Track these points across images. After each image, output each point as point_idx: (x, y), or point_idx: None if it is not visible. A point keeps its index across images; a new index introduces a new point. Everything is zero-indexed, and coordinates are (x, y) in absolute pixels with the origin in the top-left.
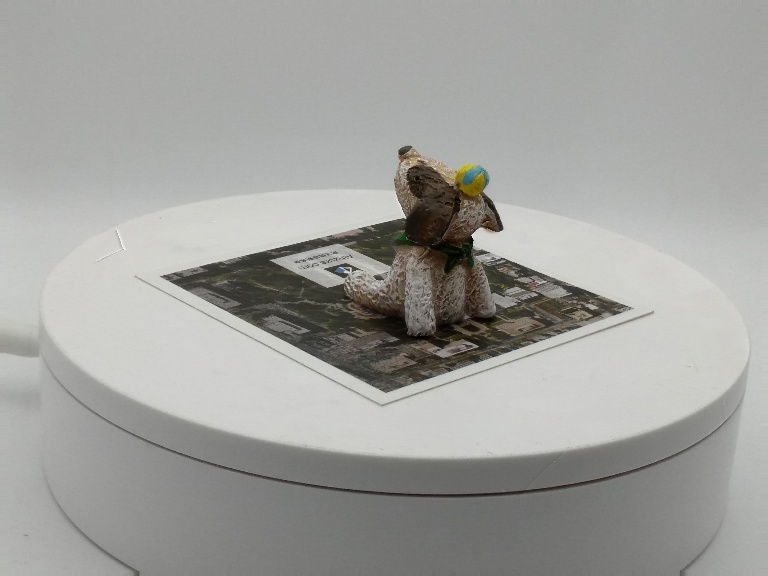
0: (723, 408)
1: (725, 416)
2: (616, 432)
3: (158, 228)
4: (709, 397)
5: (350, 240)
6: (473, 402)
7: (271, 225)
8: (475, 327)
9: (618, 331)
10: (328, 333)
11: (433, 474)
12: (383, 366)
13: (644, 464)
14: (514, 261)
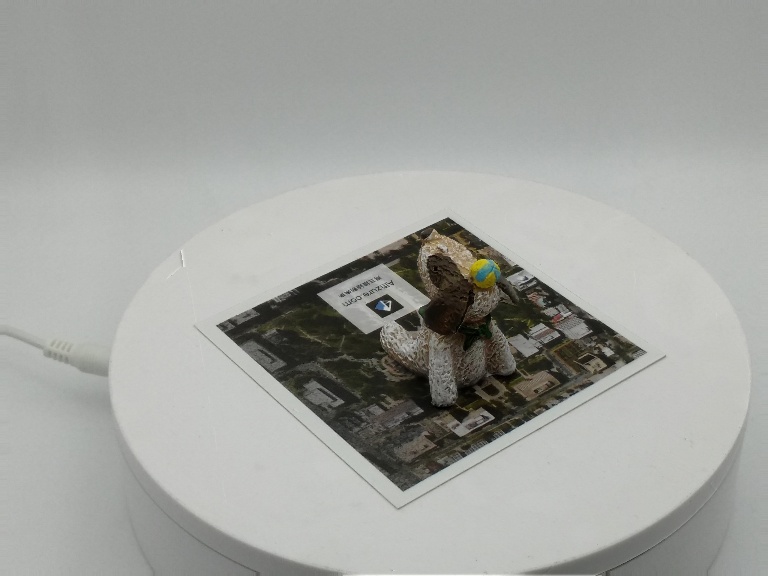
0: (711, 486)
1: (715, 488)
2: (602, 538)
3: (219, 247)
4: (696, 483)
5: (394, 257)
6: (479, 501)
7: (323, 236)
8: (495, 388)
9: (628, 386)
10: (360, 405)
11: None
12: (405, 452)
13: (629, 558)
14: (545, 282)
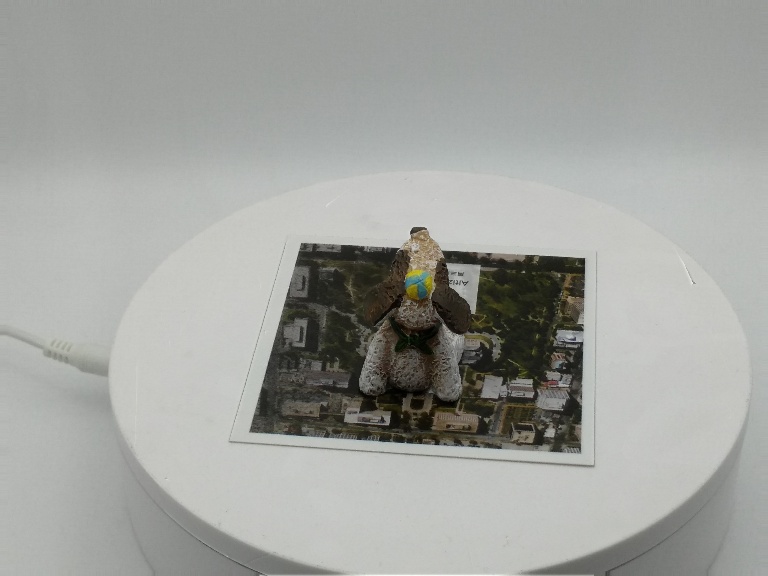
0: None
1: None
2: (332, 561)
3: (385, 190)
4: (463, 574)
5: (495, 265)
6: (289, 474)
7: (469, 221)
8: (421, 404)
9: (526, 469)
10: (311, 355)
11: (184, 516)
12: (291, 407)
13: None
14: (585, 350)
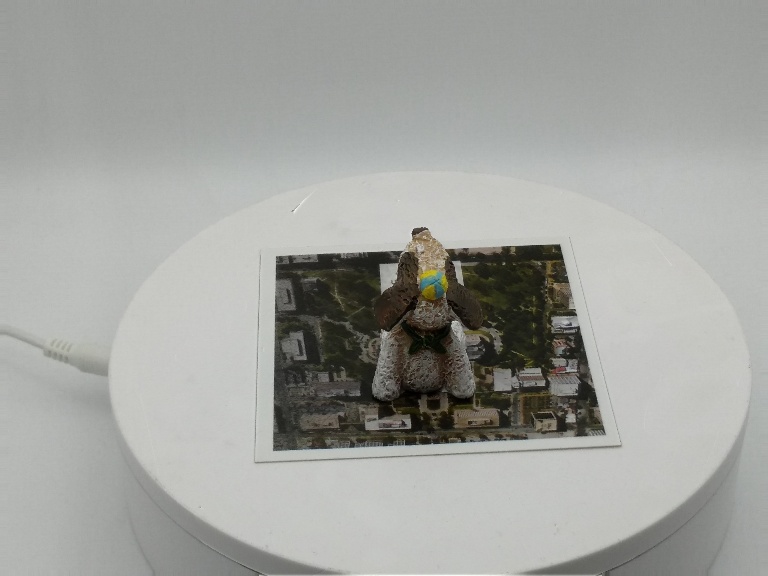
0: None
1: None
2: (390, 569)
3: (346, 195)
4: (522, 567)
5: (475, 260)
6: (324, 488)
7: (437, 219)
8: (438, 404)
9: (556, 456)
10: (316, 367)
11: (225, 543)
12: (308, 421)
13: None
14: (583, 334)
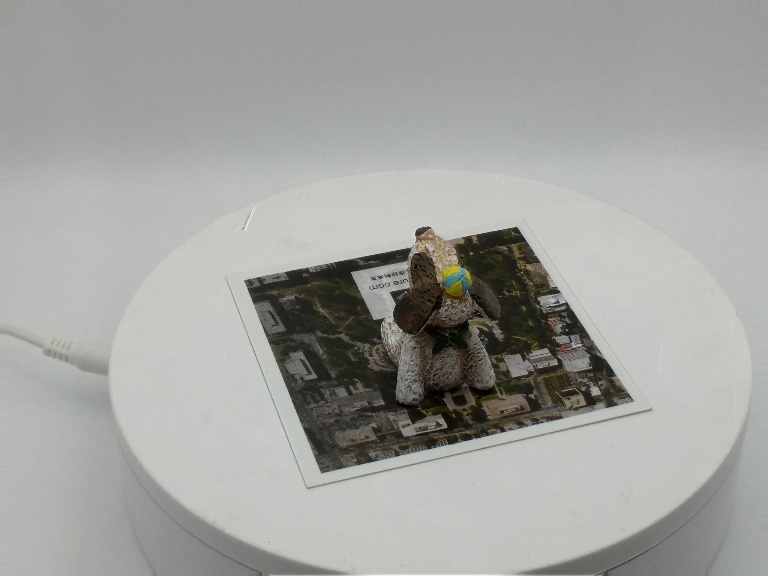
0: (628, 548)
1: (636, 552)
2: (483, 568)
3: (289, 210)
4: (607, 541)
5: None
6: (386, 501)
7: (389, 220)
8: (464, 399)
9: (596, 430)
10: (330, 384)
11: (305, 574)
12: (344, 437)
13: None
14: (574, 309)
